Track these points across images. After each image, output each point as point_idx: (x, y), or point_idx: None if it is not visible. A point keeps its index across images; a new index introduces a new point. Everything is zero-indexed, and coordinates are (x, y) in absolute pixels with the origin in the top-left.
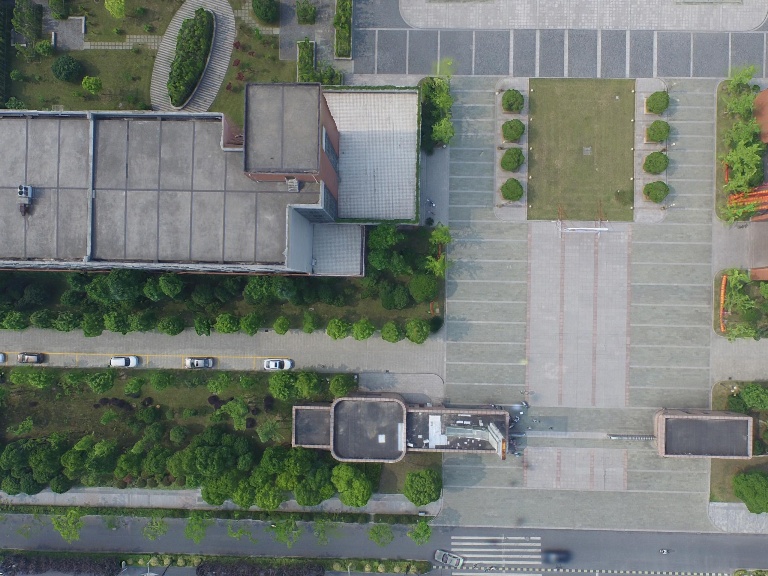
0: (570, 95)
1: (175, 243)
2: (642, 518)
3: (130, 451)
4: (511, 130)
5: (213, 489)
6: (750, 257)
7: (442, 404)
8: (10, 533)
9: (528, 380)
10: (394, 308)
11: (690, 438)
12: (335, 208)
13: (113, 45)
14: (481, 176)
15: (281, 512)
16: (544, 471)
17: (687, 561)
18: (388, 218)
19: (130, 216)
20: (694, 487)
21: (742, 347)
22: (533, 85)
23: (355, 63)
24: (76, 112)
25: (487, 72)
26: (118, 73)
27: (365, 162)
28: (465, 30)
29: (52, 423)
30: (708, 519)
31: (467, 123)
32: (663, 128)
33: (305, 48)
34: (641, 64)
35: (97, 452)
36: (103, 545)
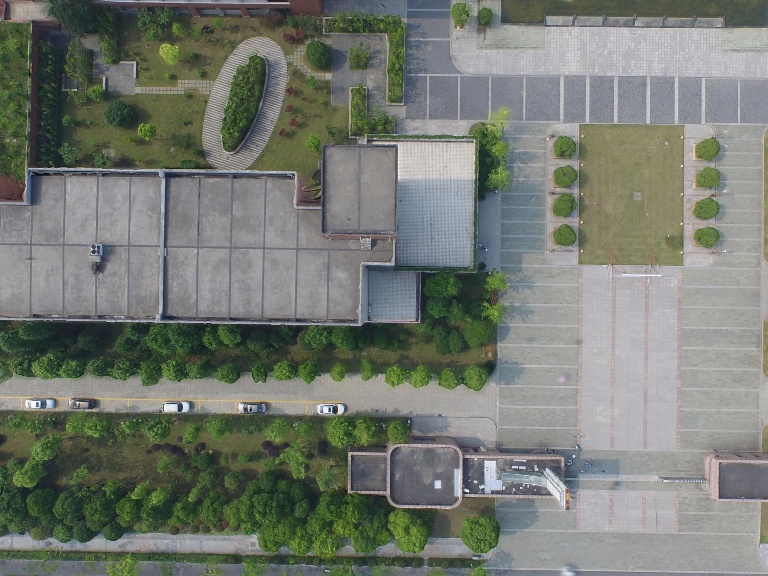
0: (620, 141)
1: (247, 301)
2: (693, 560)
3: (185, 499)
4: (564, 177)
5: (271, 537)
6: None
7: (495, 448)
8: None
9: (580, 423)
10: (448, 353)
11: (743, 482)
12: None
13: (165, 90)
14: (532, 221)
15: (334, 557)
16: (596, 514)
17: None
18: (445, 266)
19: (202, 274)
20: (745, 529)
21: None
22: (583, 131)
23: (407, 108)
24: (148, 170)
25: (538, 118)
26: (170, 118)
27: (422, 210)
28: (516, 76)
29: (104, 469)
30: (758, 560)
31: (518, 168)
32: (714, 175)
33: (358, 94)
34: (690, 110)
35: (154, 501)
36: None
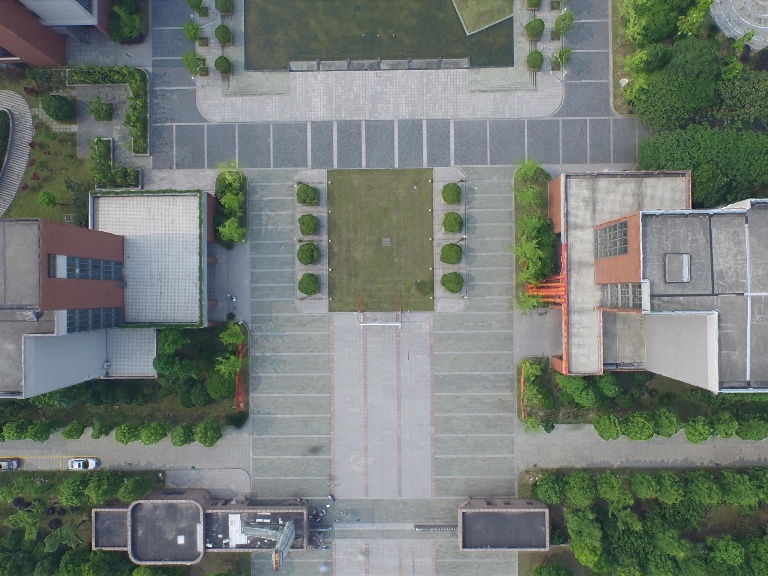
0: (368, 186)
1: None
2: None
3: None
4: (303, 226)
5: None
6: (551, 344)
7: (247, 500)
8: None
9: (334, 473)
10: None
11: (489, 530)
12: (117, 315)
13: None
14: (282, 269)
15: None
16: (353, 563)
17: None
18: (175, 321)
19: None
20: (502, 575)
21: (546, 434)
22: (331, 177)
23: (154, 159)
24: None
25: (285, 165)
26: None
27: (150, 266)
28: (262, 123)
29: None
30: None
31: (267, 216)
32: (453, 221)
33: (100, 146)
34: (438, 153)
35: None
36: None
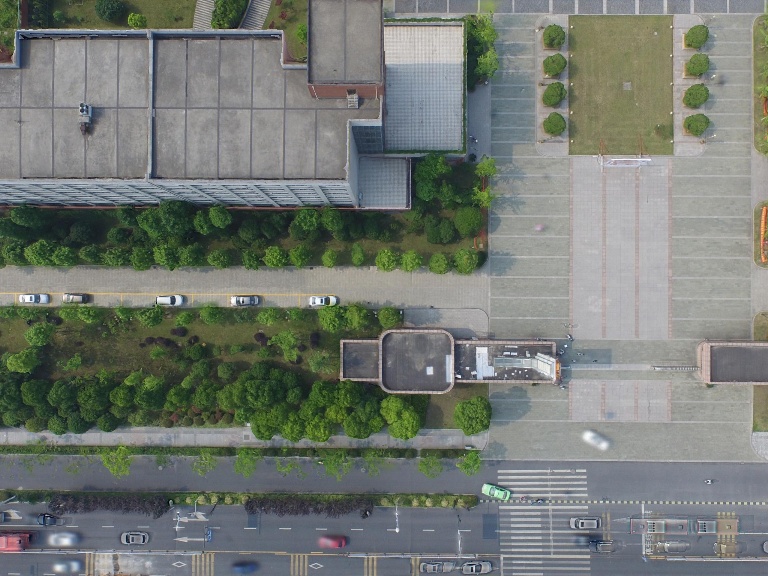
0: (609, 31)
1: (235, 161)
2: (686, 449)
3: (178, 387)
4: (554, 64)
5: (263, 421)
6: None
7: (487, 338)
8: (56, 475)
9: (572, 313)
10: (439, 242)
11: (734, 366)
12: None
13: None
14: (522, 112)
15: (328, 448)
16: (589, 404)
17: (731, 491)
18: (435, 149)
19: (190, 134)
20: (737, 417)
21: None
22: (573, 22)
23: (396, 2)
24: (136, 31)
25: (527, 10)
26: (160, 14)
27: (411, 94)
28: None
29: (98, 363)
30: (751, 449)
31: (508, 60)
32: (703, 60)
33: None
34: (678, 0)
35: (147, 385)
36: (149, 485)
